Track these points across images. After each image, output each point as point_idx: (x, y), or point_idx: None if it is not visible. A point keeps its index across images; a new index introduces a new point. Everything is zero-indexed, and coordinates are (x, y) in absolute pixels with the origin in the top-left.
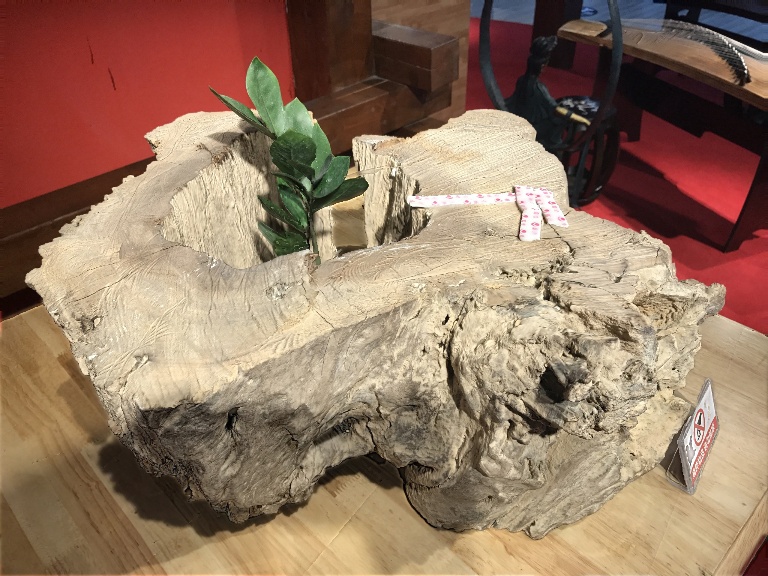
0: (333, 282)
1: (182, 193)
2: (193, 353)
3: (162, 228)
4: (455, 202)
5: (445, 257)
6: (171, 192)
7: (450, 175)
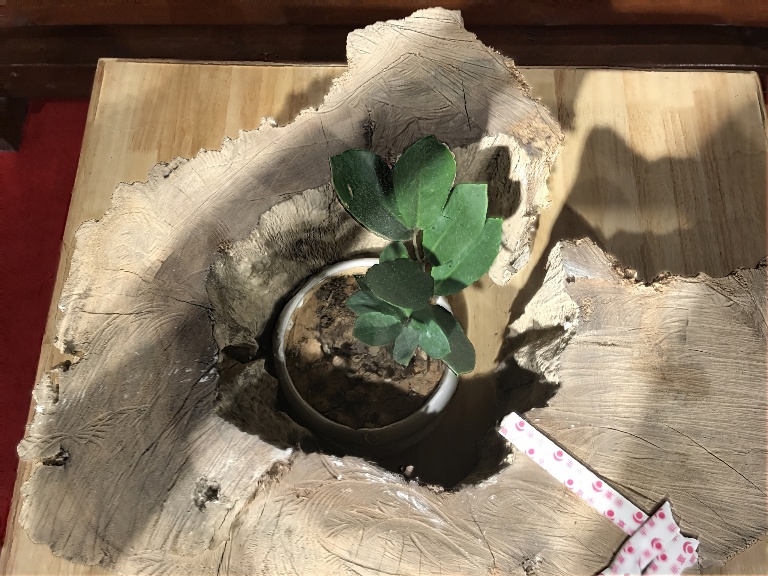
0: (288, 501)
1: (290, 201)
2: (92, 497)
3: (227, 251)
4: (555, 471)
5: (434, 564)
6: (275, 197)
7: (616, 404)
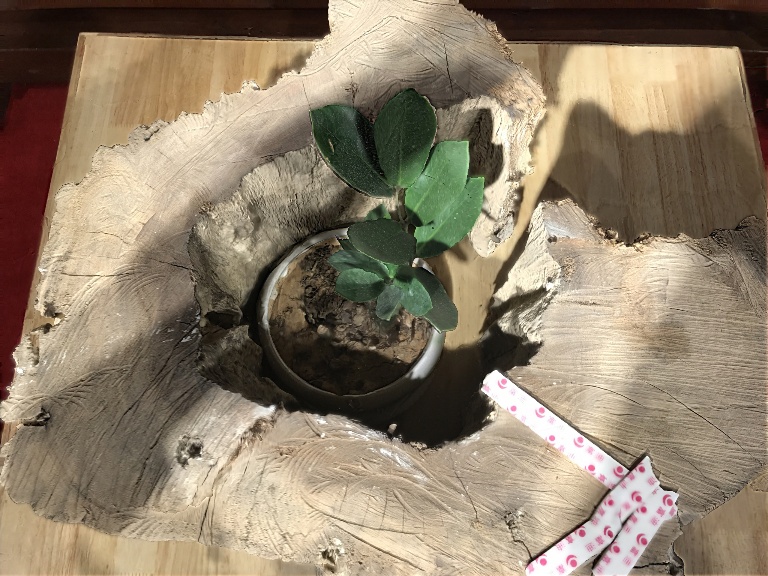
0: (272, 459)
1: (272, 163)
2: (74, 456)
3: (209, 213)
4: (537, 428)
5: (417, 519)
6: (257, 159)
7: (597, 362)
